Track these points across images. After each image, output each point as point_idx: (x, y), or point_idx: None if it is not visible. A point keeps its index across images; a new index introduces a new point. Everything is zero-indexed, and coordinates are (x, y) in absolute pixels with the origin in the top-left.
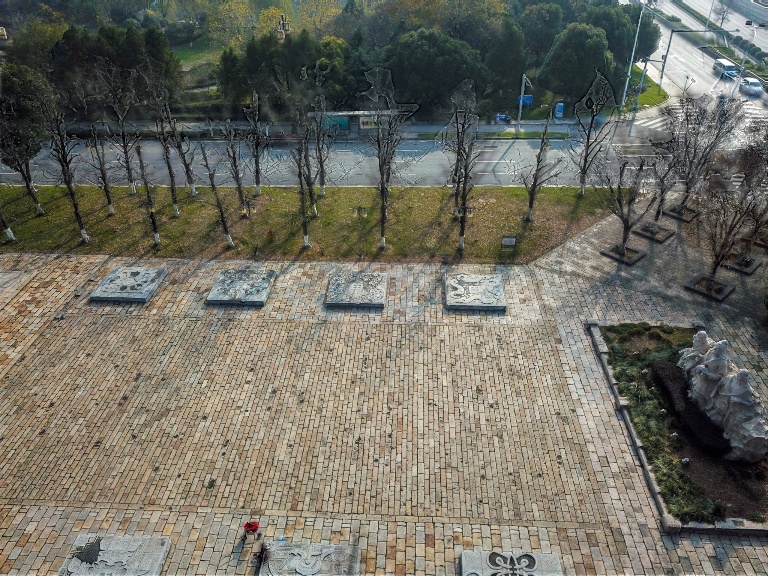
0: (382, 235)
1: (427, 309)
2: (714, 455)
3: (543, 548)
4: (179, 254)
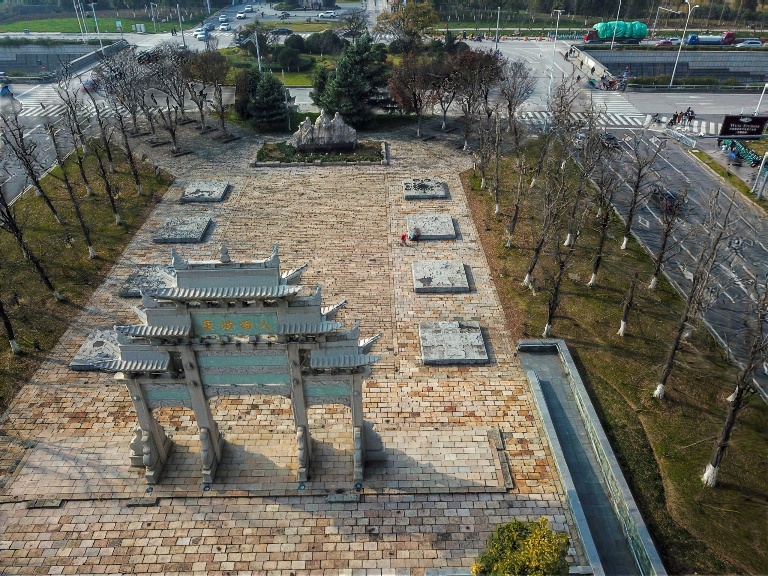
0: (116, 213)
1: (217, 208)
2: (352, 149)
3: (398, 185)
4: (56, 332)
